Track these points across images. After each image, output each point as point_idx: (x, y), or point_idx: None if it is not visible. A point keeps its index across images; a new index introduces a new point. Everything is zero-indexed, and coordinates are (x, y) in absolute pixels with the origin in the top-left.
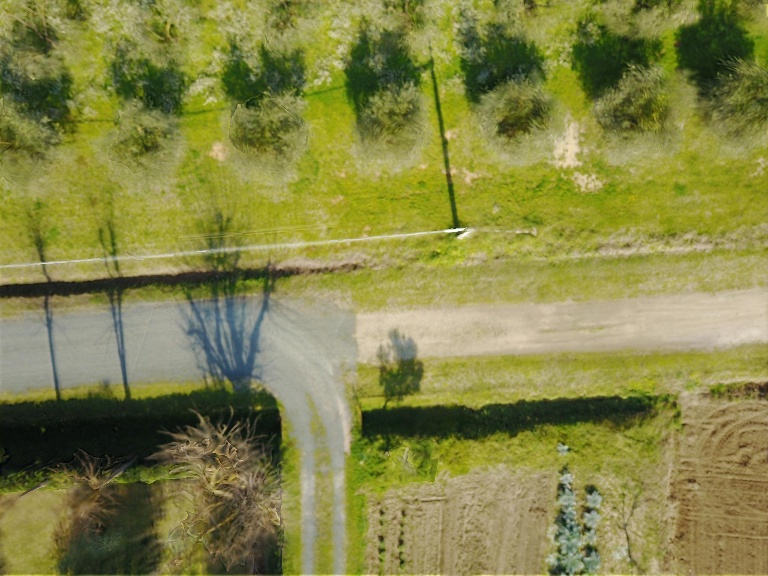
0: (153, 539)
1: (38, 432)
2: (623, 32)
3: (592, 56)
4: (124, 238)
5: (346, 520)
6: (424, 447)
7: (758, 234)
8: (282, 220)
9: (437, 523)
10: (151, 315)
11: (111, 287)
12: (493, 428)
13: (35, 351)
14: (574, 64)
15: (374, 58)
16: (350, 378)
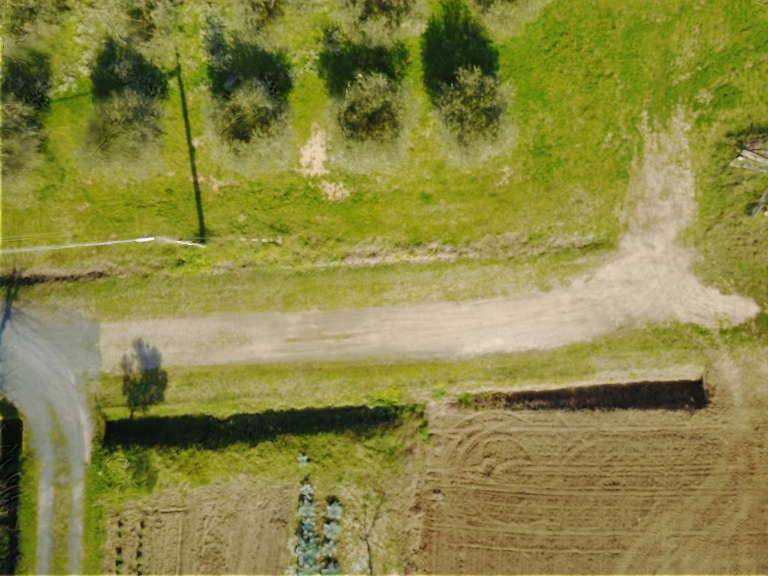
0: None
1: None
2: (360, 40)
3: (338, 64)
4: None
5: (84, 532)
6: (139, 458)
7: (502, 243)
8: (26, 227)
9: (177, 534)
10: None
11: None
12: (235, 438)
13: None
14: (321, 72)
15: (119, 64)
16: (93, 388)
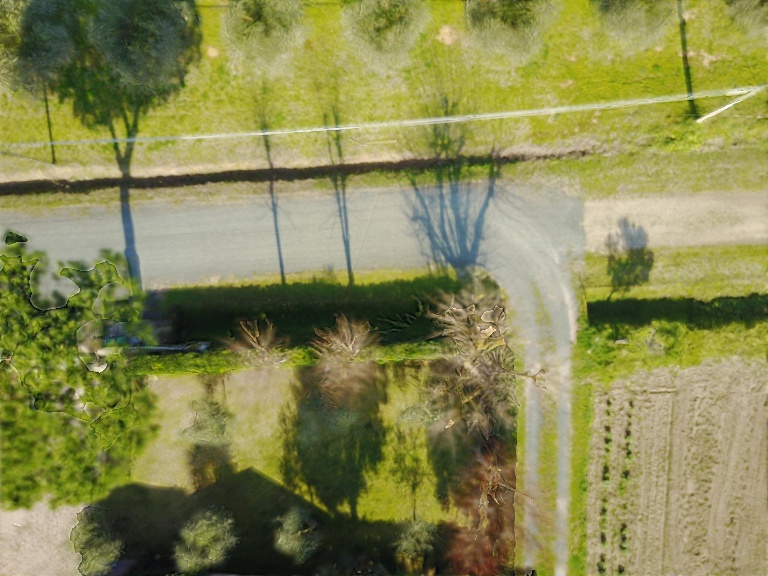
0: (378, 422)
1: (260, 317)
2: None
3: None
4: (348, 123)
5: (572, 409)
6: (675, 328)
7: None
8: (509, 105)
9: (666, 415)
10: (375, 201)
11: (334, 173)
12: (728, 320)
13: (261, 235)
14: None
15: None
16: (577, 267)
